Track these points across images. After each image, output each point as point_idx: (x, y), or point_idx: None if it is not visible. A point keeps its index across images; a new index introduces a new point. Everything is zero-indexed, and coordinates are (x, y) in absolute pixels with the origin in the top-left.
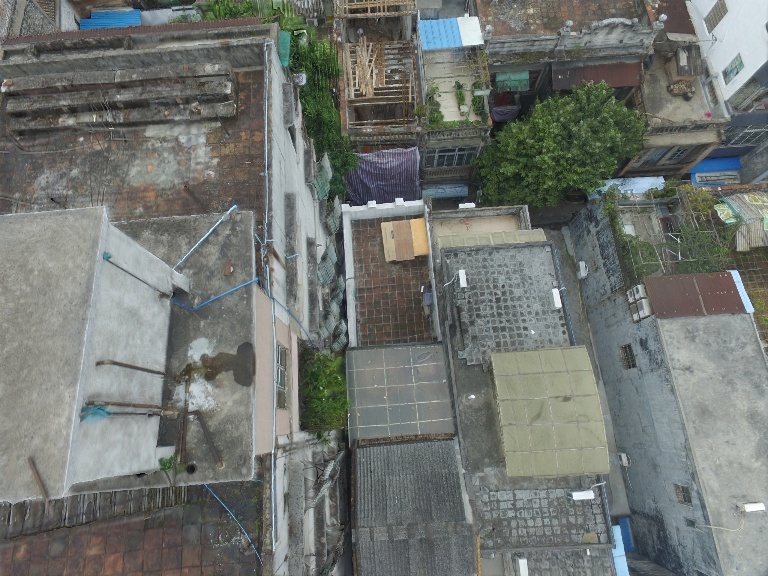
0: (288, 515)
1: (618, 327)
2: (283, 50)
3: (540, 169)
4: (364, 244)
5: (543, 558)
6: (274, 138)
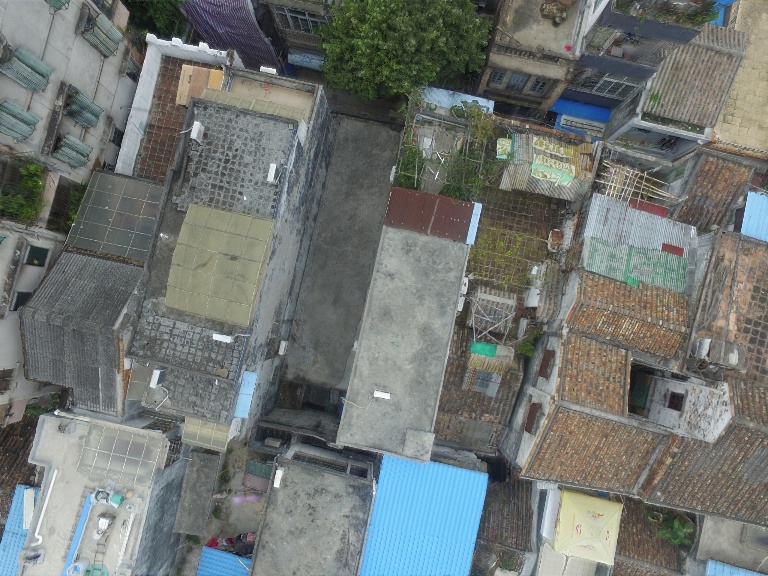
0: None
1: None
2: None
3: None
4: (168, 82)
5: (181, 376)
6: None
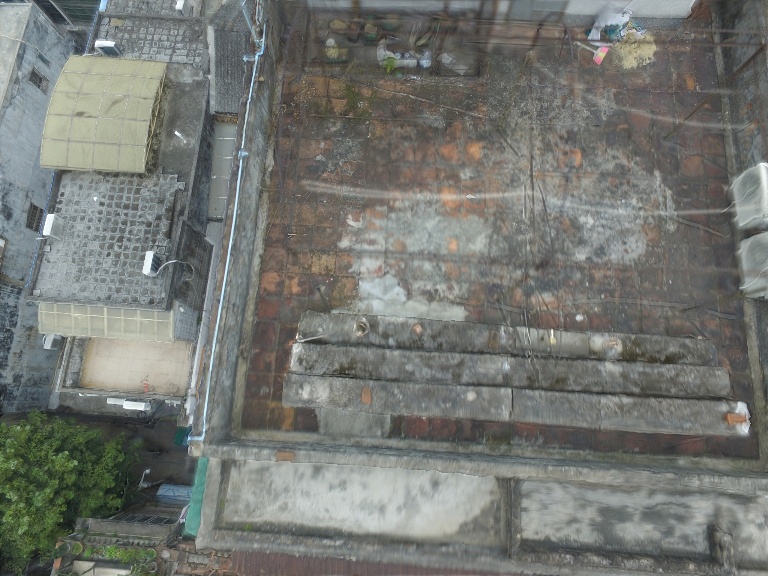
0: None
1: None
2: None
3: (24, 457)
4: None
5: None
6: None
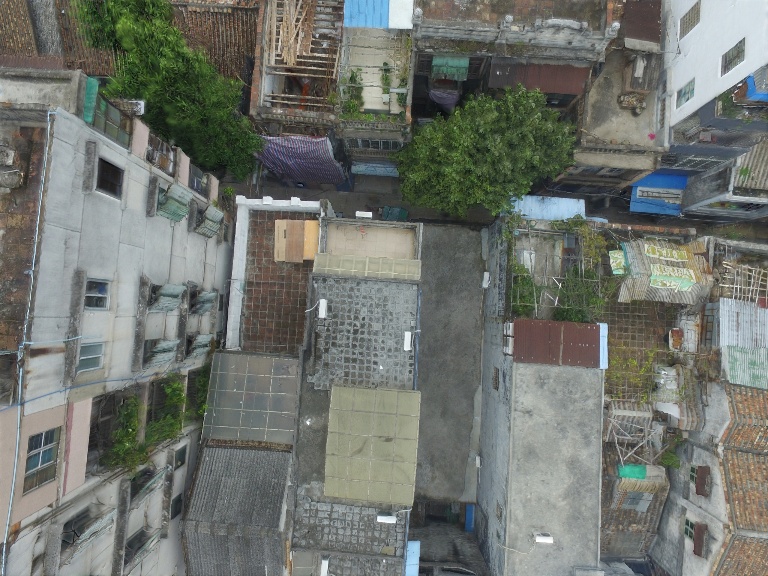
0: (43, 570)
1: (496, 349)
2: (88, 103)
3: None
4: (259, 237)
5: (347, 559)
6: (50, 226)
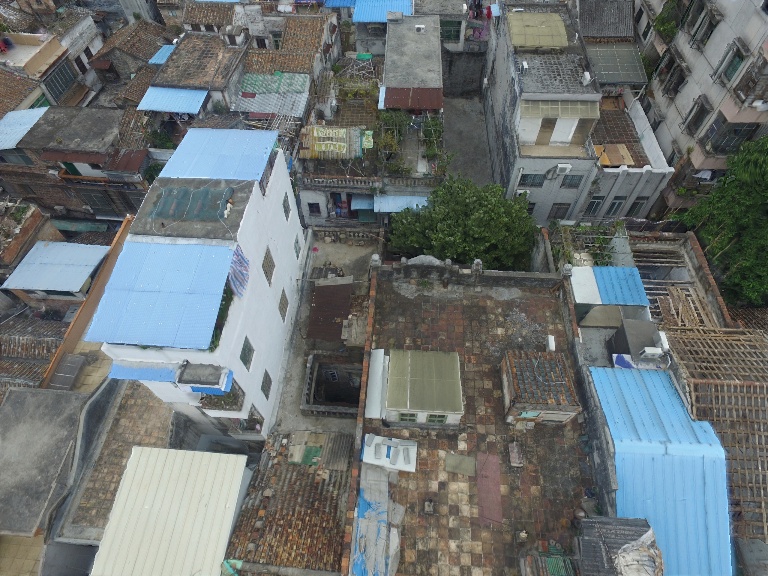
0: None
1: None
2: None
3: None
4: (642, 165)
5: None
6: None
